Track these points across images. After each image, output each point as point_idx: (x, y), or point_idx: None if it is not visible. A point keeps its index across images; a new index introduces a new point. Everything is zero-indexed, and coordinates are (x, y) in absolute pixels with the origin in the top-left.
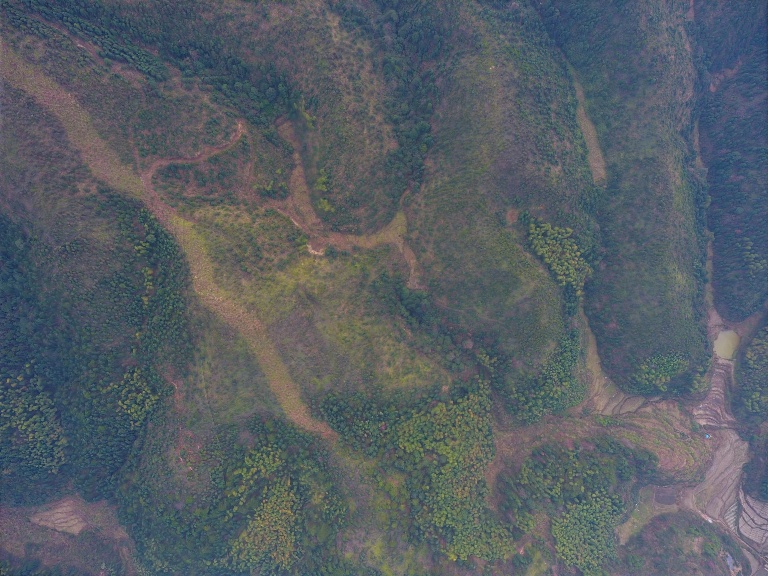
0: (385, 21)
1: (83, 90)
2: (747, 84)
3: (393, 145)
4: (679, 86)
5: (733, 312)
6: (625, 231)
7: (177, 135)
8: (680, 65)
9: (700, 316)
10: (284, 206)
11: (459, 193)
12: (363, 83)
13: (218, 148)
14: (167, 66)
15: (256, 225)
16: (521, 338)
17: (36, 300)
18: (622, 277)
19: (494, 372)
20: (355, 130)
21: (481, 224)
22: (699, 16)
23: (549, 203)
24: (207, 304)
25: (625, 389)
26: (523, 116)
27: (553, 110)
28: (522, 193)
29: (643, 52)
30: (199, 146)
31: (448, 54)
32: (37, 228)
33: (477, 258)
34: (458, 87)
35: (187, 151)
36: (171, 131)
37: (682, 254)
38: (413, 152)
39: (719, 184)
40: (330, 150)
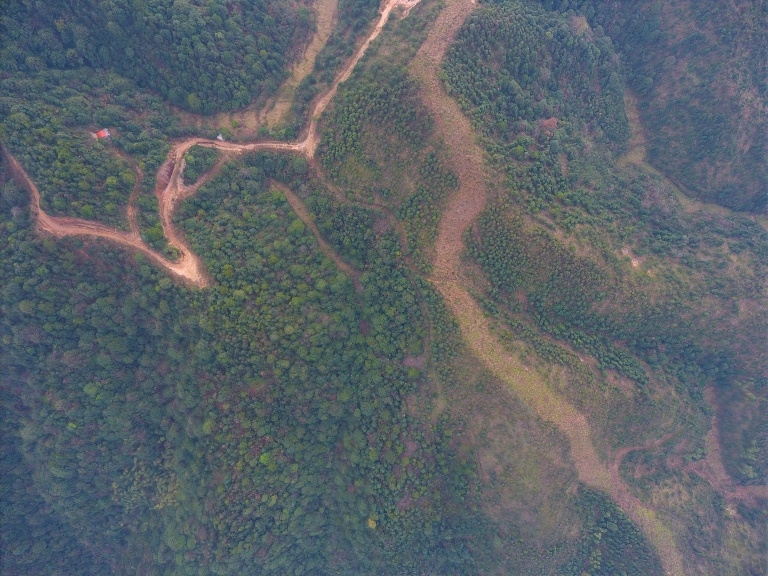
0: None
1: (592, 409)
2: None
3: None
4: None
5: None
6: None
7: (651, 432)
8: None
9: None
10: (699, 466)
11: None
12: None
13: None
14: None
15: (694, 499)
16: None
17: (476, 574)
18: None
19: None
20: None
21: None
22: None
23: None
24: None
25: None
26: None
27: None
28: None
29: None
30: None
31: None
32: (529, 535)
33: None
34: None
35: (650, 441)
36: (648, 430)
37: None
38: None
39: None
40: (767, 425)
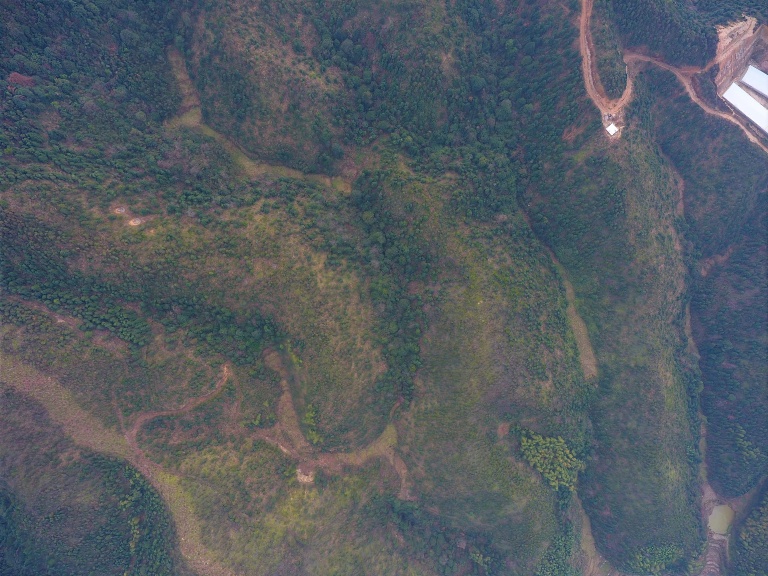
0: (372, 243)
1: (64, 370)
2: (738, 275)
3: (382, 368)
4: (669, 288)
5: (727, 491)
6: (617, 428)
7: (161, 395)
8: (670, 270)
9: (694, 496)
10: (272, 433)
11: (449, 423)
12: (350, 318)
13: (203, 397)
14: (150, 323)
15: (244, 465)
16: (514, 543)
17: (21, 546)
18: (615, 471)
19: (488, 568)
20: (342, 369)
21: (472, 450)
22: (689, 210)
23: (540, 417)
24: (194, 568)
25: (620, 570)
26: (512, 344)
27: (543, 321)
28: (513, 410)
29: (633, 264)
30: (184, 400)
31: (436, 279)
32: (19, 502)
33: (468, 482)
34: (446, 319)
35: (172, 406)
36: (155, 393)
37: (675, 447)
38: (402, 369)
39: (711, 368)
40: (318, 388)
